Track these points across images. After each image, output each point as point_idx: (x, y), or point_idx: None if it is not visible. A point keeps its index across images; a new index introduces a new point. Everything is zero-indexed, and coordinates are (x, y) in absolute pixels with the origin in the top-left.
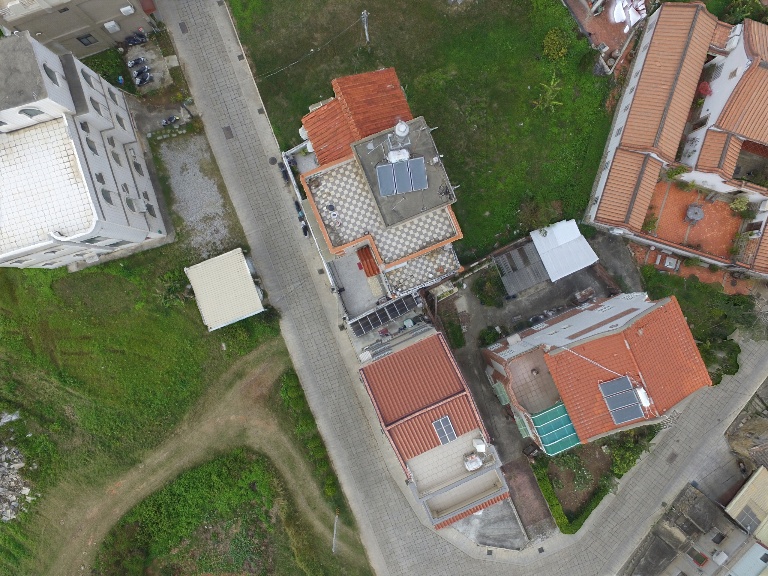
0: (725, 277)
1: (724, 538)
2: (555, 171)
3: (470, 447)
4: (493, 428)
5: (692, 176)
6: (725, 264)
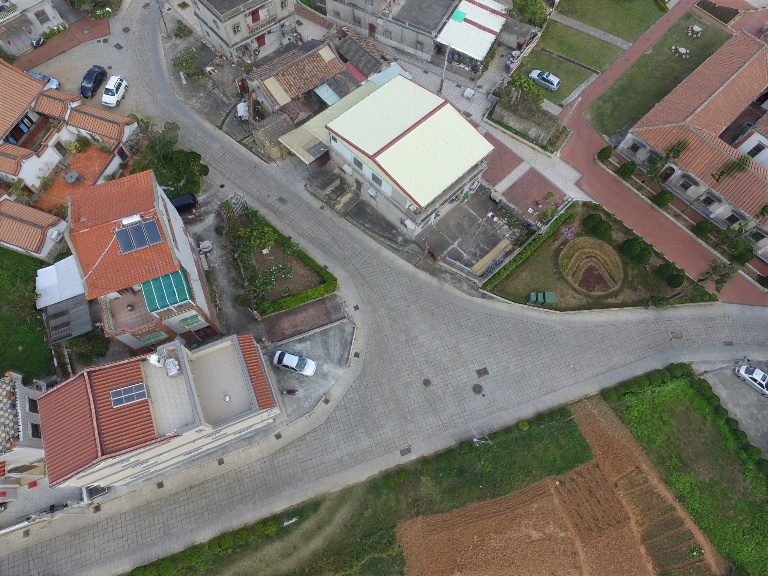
0: (136, 158)
1: (339, 166)
2: None
3: (163, 370)
4: None
5: (32, 178)
6: (117, 158)
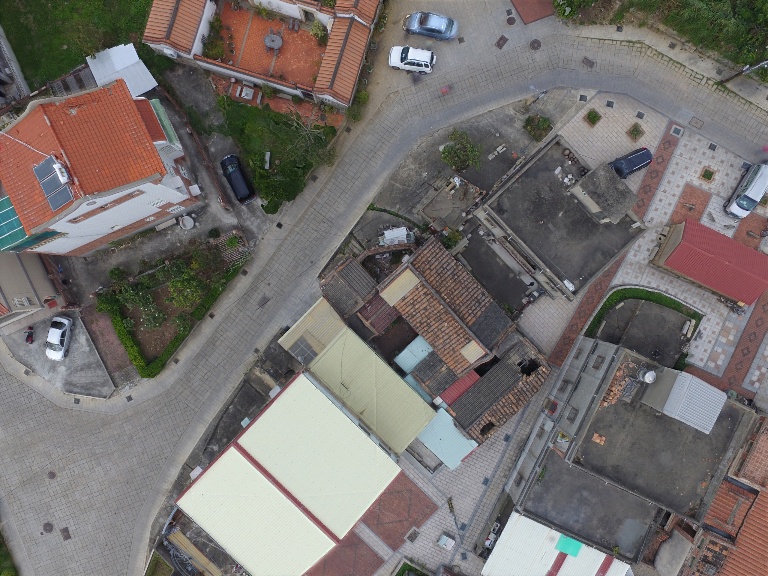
0: (314, 111)
1: None
2: (134, 2)
3: None
4: (71, 269)
5: None
6: (298, 92)
